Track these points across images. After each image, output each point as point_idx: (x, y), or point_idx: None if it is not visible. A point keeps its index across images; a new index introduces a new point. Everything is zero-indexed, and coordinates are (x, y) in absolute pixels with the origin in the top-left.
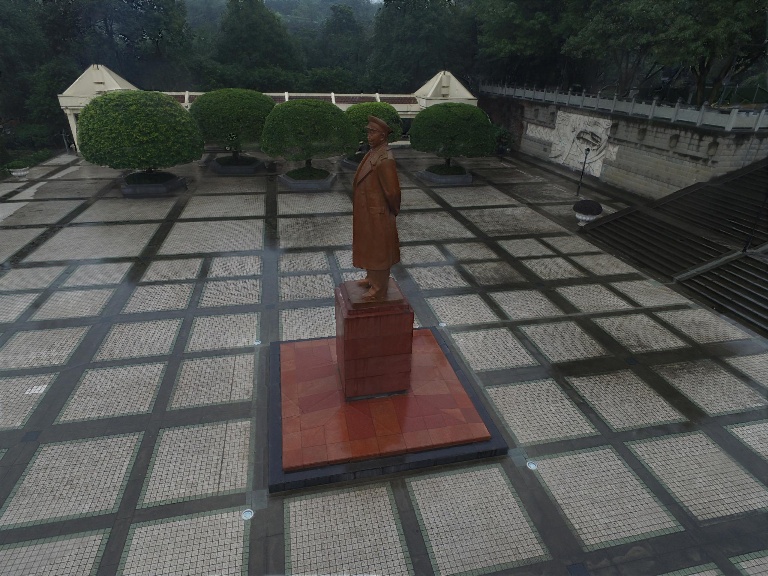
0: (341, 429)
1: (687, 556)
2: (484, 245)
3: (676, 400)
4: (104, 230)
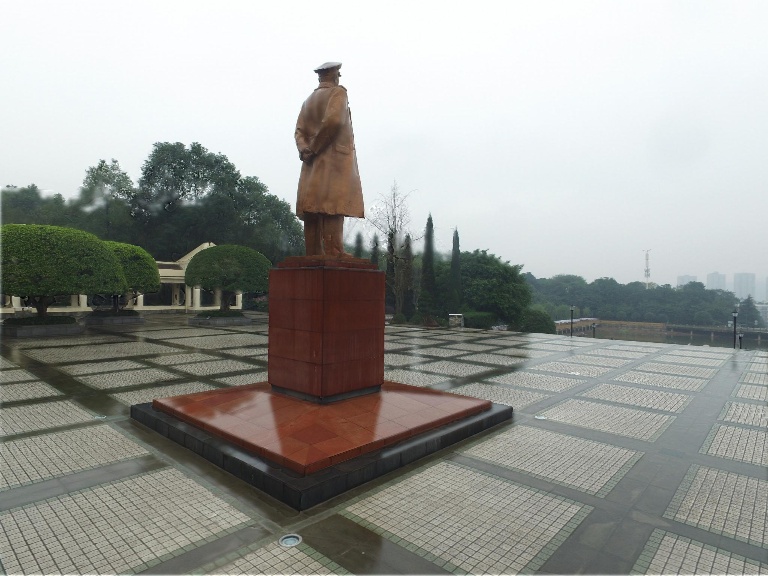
0: None
1: None
2: None
3: None
4: None
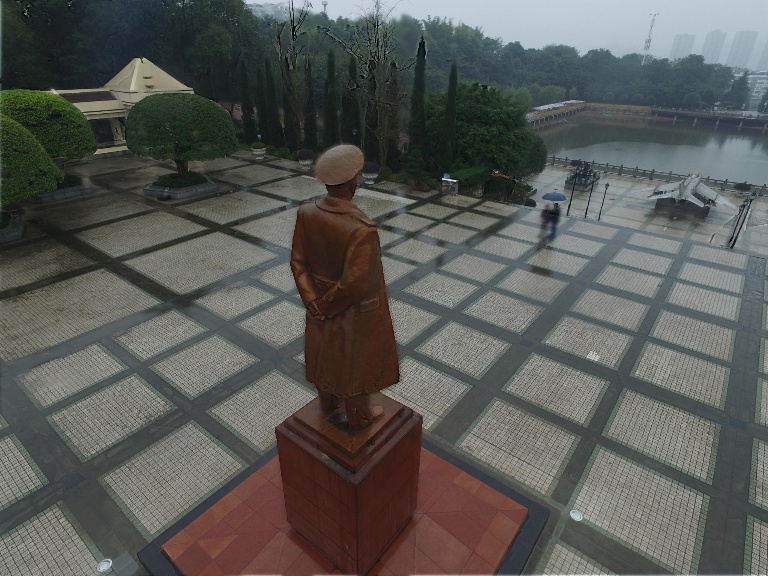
0: None
1: None
2: None
3: None
4: None
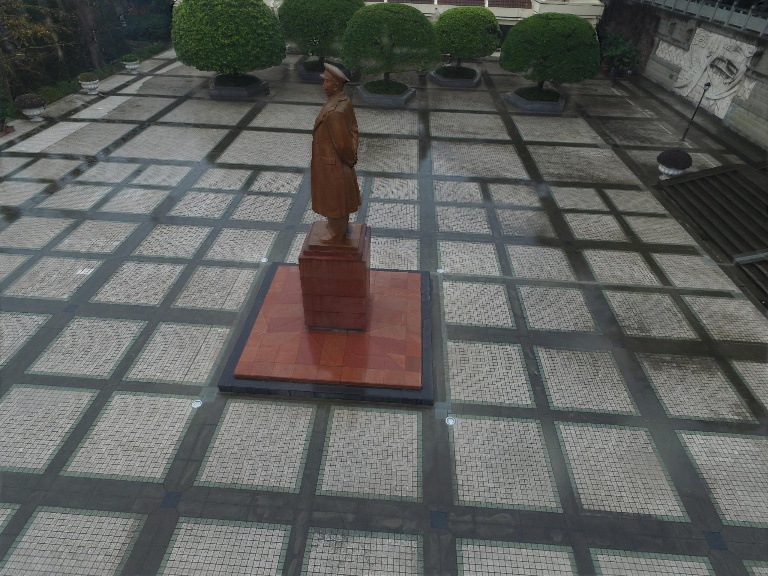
0: (292, 352)
1: (549, 535)
2: (533, 190)
3: (641, 393)
4: (181, 132)
